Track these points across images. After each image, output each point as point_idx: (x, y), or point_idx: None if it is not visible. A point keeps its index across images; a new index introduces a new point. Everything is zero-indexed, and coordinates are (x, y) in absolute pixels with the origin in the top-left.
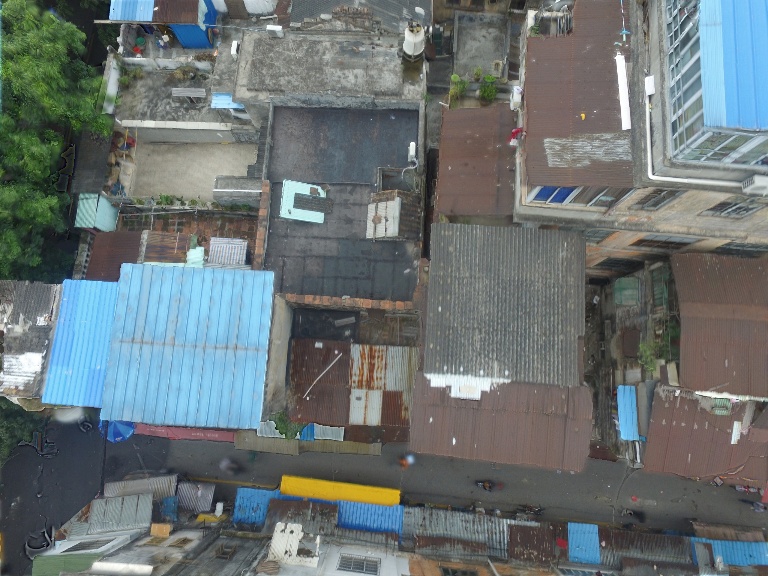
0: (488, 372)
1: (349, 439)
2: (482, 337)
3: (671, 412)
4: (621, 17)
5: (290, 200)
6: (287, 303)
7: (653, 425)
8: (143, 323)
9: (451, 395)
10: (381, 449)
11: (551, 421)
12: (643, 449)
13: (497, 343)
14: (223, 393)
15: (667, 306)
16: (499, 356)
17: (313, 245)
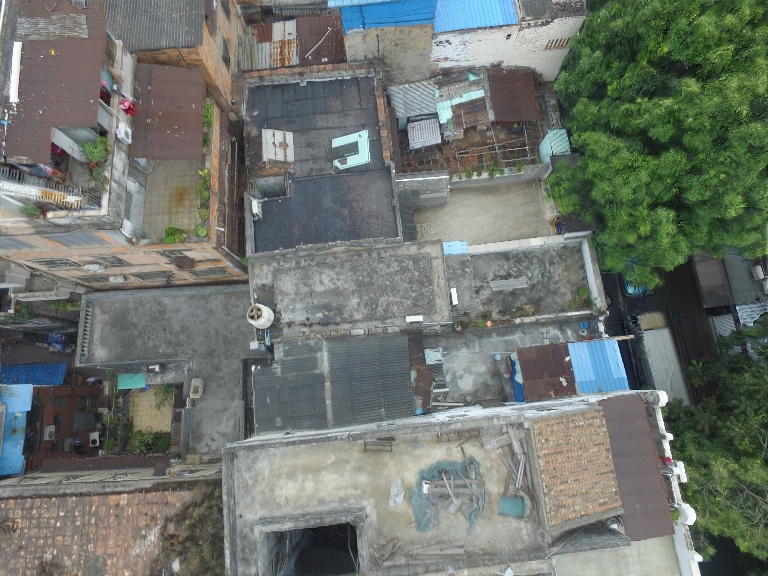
0: None
1: None
2: None
3: (43, 1)
4: (7, 140)
5: (362, 146)
6: None
7: None
8: None
9: None
10: None
11: None
12: None
13: None
14: None
15: None
16: None
17: (338, 121)
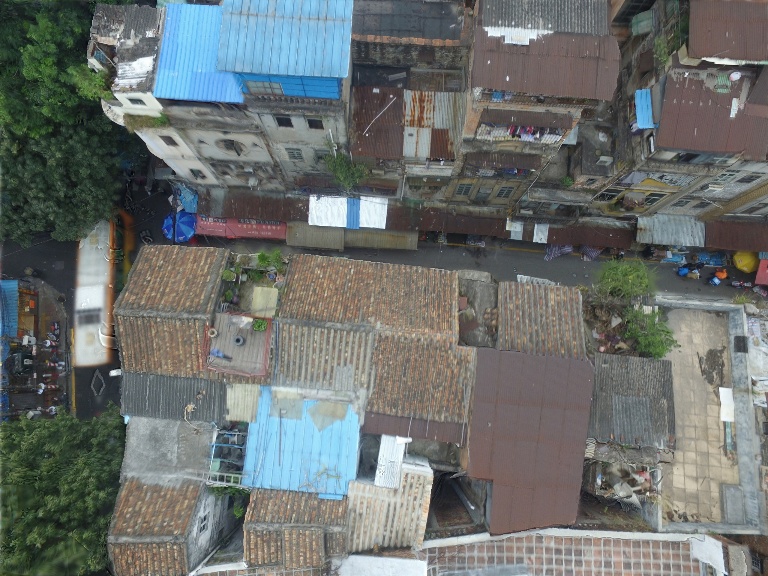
0: (535, 26)
1: (390, 227)
2: (529, 1)
3: (681, 91)
4: None
5: None
6: (352, 43)
7: (666, 103)
8: (249, 0)
9: (505, 43)
10: (417, 244)
11: (586, 62)
12: (657, 135)
13: (542, 5)
14: (317, 52)
15: (678, 9)
16: (543, 14)
17: (371, 6)
